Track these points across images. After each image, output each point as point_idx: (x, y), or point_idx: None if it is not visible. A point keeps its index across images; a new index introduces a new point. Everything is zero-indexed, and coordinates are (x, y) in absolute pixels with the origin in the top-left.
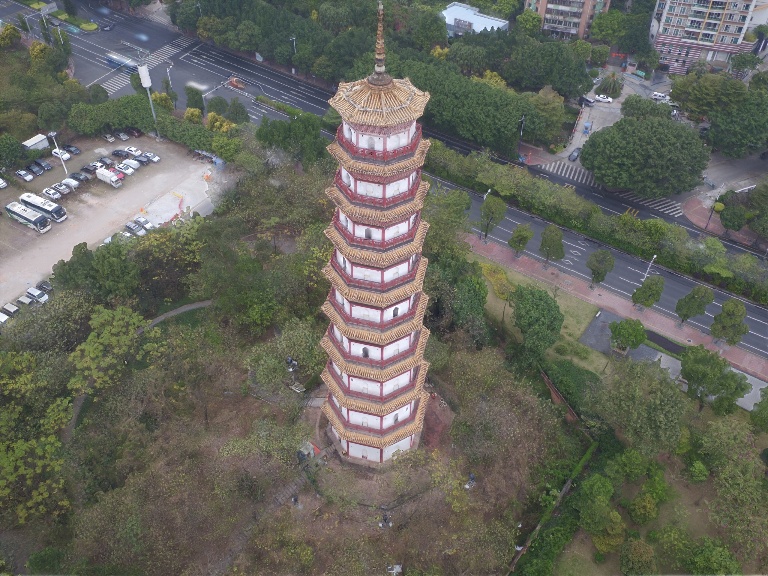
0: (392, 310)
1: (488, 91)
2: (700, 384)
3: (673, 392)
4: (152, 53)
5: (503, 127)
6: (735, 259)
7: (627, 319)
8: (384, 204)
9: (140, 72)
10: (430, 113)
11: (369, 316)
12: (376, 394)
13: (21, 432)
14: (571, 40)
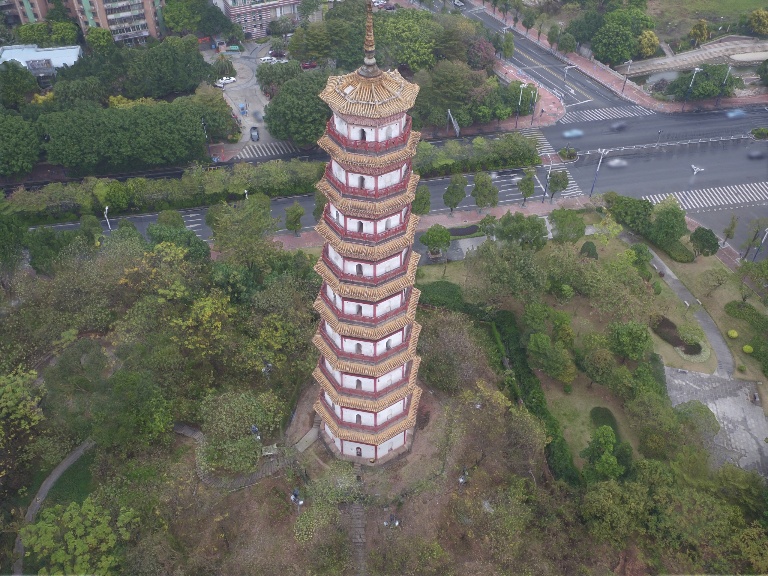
0: None
1: (153, 110)
2: (519, 237)
3: None
4: None
5: (193, 136)
6: (448, 148)
7: None
8: (405, 186)
9: None
10: (102, 158)
11: (390, 306)
12: (398, 379)
13: None
14: (147, 43)
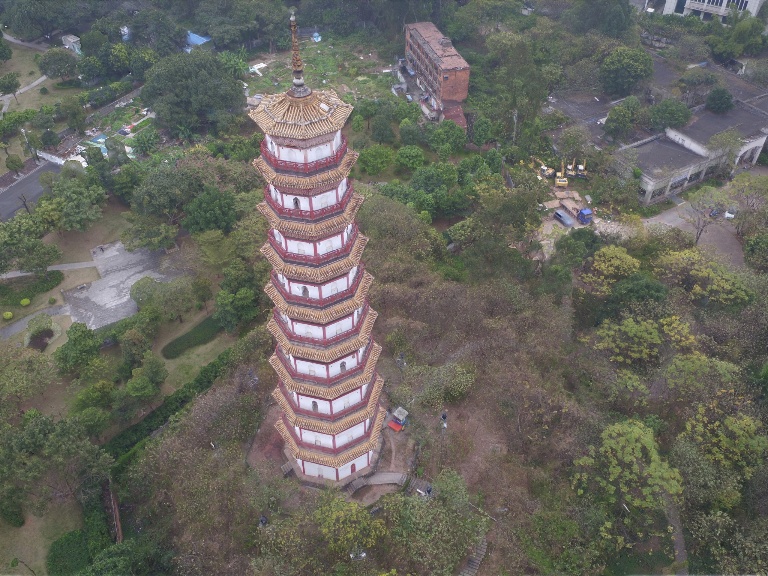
0: None
1: None
2: None
3: (7, 452)
4: None
5: None
6: None
7: None
8: None
9: None
10: None
11: None
12: None
13: None
14: None
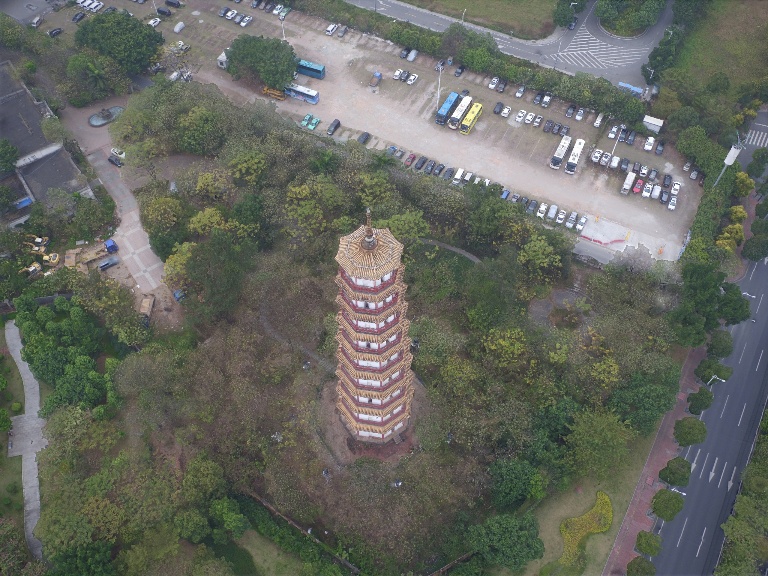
0: None
1: None
2: None
3: None
4: None
5: None
6: None
7: None
8: None
9: (731, 150)
10: None
11: None
12: None
13: (355, 215)
14: None
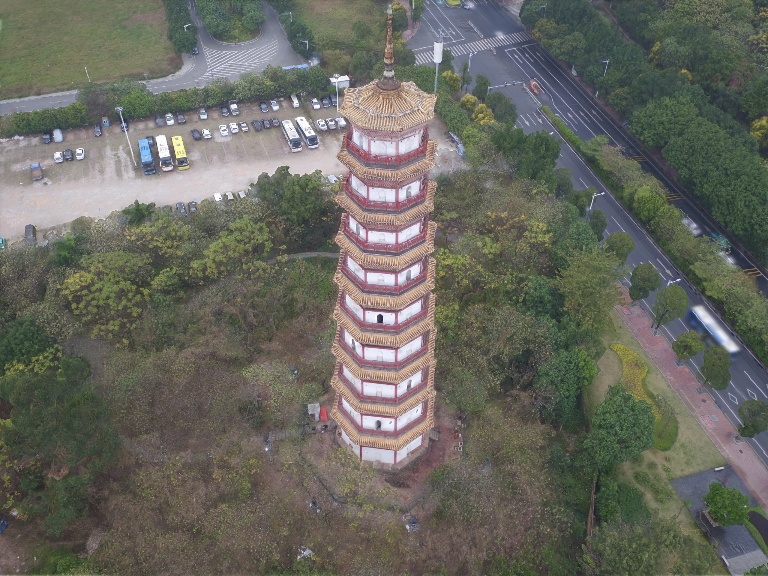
0: (376, 315)
1: (766, 180)
2: None
3: None
4: (486, 39)
5: (758, 225)
6: None
7: (735, 489)
8: (364, 205)
9: (435, 47)
10: None
11: (357, 310)
12: (359, 390)
13: None
14: None
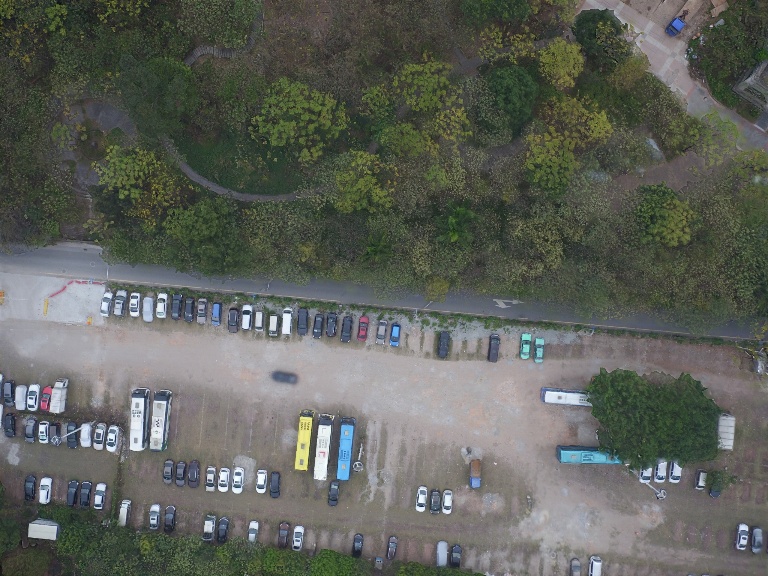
0: None
1: None
2: None
3: None
4: None
5: None
6: None
7: None
8: None
9: None
10: None
11: None
12: None
13: None
14: None
